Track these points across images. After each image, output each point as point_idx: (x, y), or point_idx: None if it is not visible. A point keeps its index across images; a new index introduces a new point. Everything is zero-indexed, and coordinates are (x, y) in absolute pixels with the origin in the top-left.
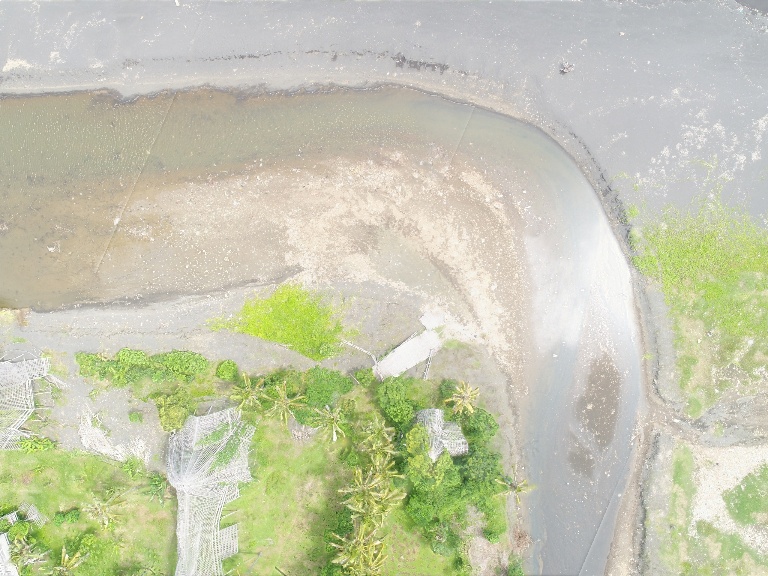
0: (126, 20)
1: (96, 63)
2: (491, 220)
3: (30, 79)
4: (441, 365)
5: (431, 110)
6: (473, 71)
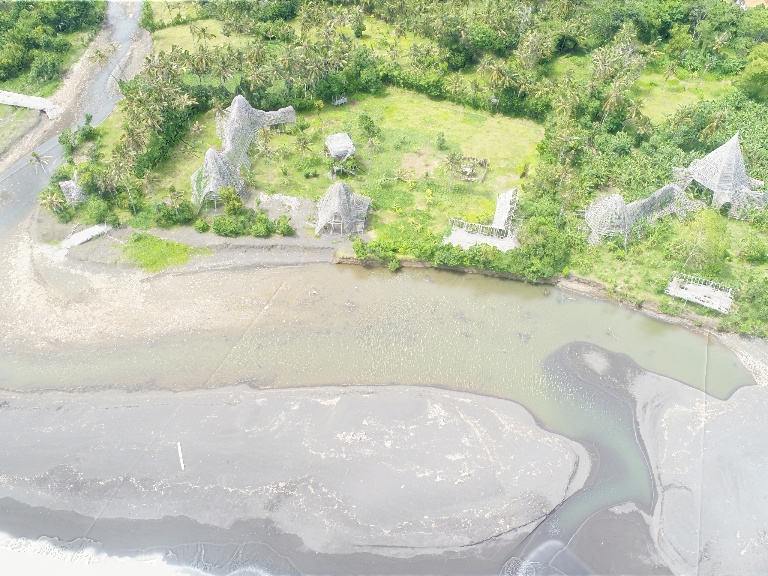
0: (228, 432)
1: (262, 402)
2: None
3: (320, 394)
4: (65, 230)
5: None
6: None
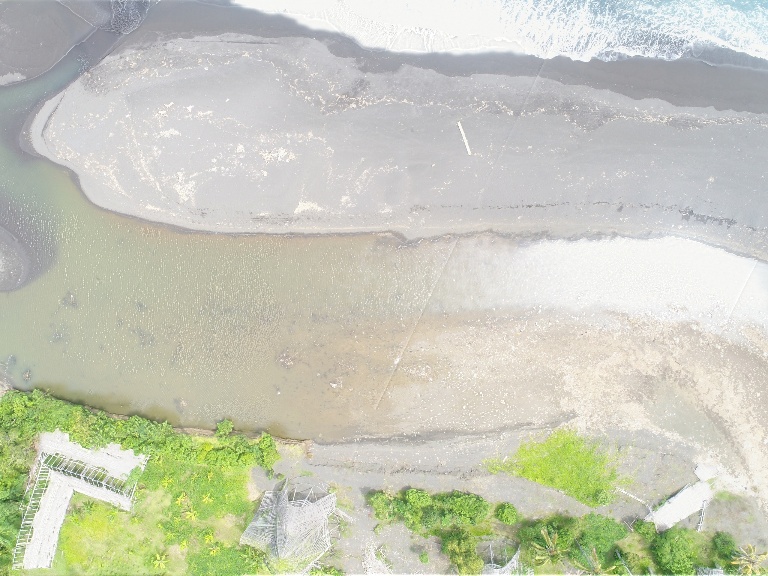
0: (417, 167)
1: (385, 208)
2: (767, 375)
3: (319, 220)
4: (715, 518)
5: (713, 262)
6: (762, 227)
